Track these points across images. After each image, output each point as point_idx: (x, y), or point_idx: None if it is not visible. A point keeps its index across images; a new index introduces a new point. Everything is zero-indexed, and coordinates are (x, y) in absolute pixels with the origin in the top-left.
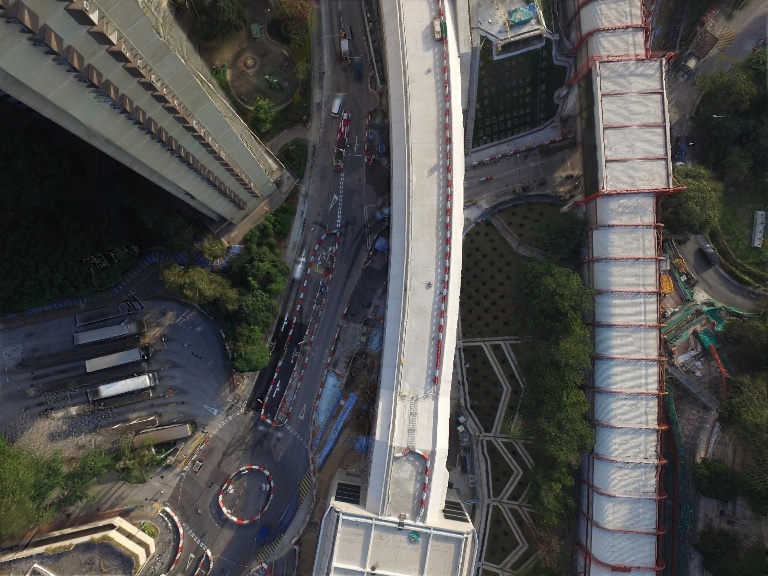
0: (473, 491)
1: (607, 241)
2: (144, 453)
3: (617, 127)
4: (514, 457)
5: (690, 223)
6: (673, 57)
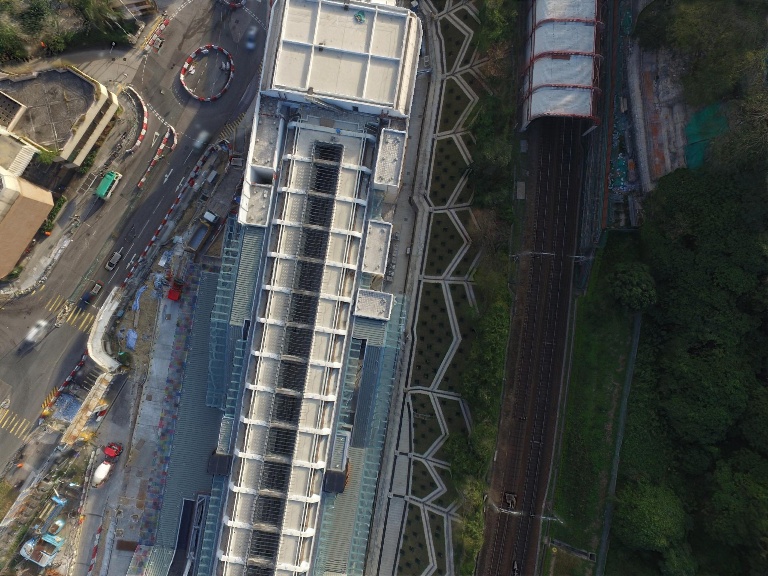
0: (427, 68)
1: None
2: None
3: None
4: (465, 21)
5: None
6: None
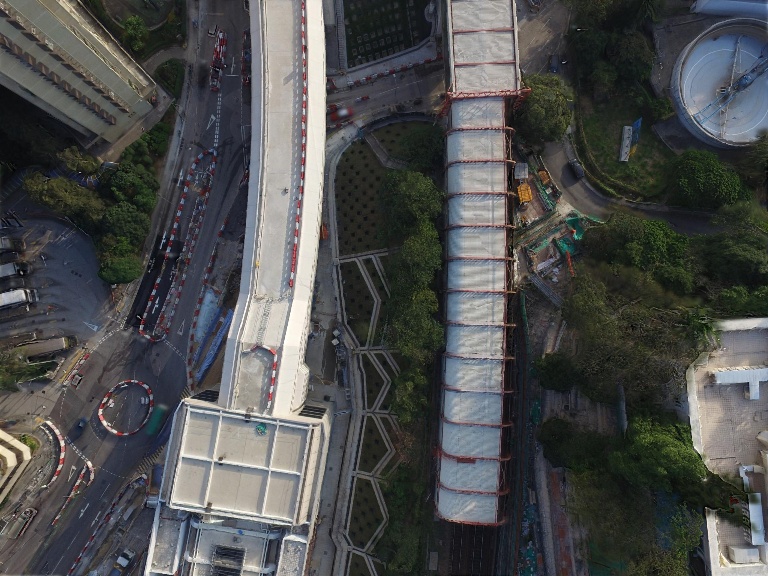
0: (348, 403)
1: (458, 145)
2: (14, 361)
3: (466, 32)
4: (384, 367)
5: (539, 127)
6: None
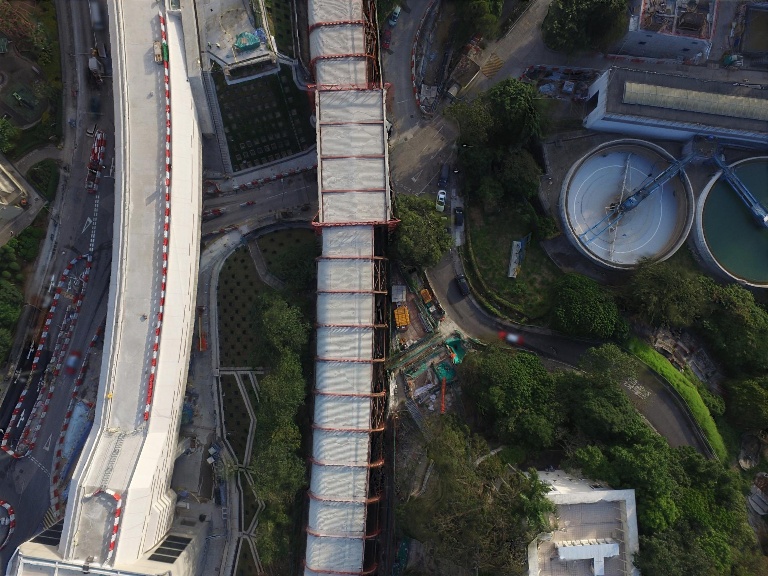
0: (224, 524)
1: (325, 274)
2: None
3: (335, 158)
4: None
5: (410, 256)
6: (442, 83)
